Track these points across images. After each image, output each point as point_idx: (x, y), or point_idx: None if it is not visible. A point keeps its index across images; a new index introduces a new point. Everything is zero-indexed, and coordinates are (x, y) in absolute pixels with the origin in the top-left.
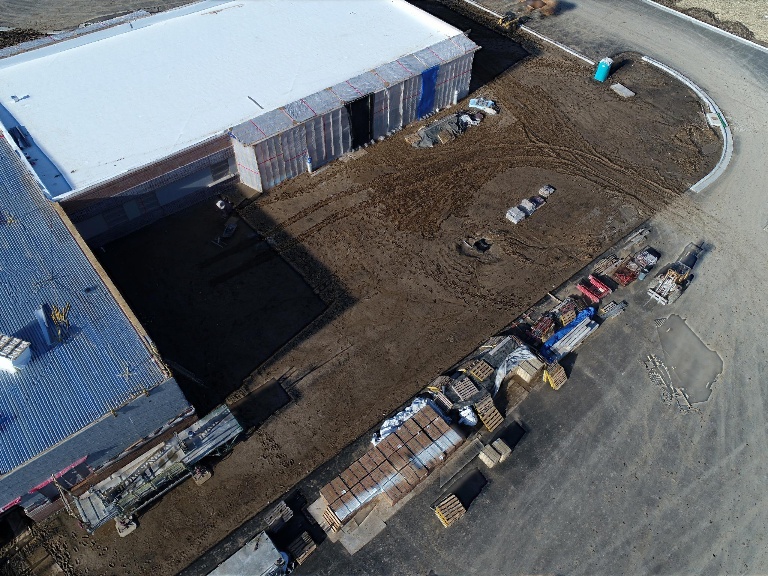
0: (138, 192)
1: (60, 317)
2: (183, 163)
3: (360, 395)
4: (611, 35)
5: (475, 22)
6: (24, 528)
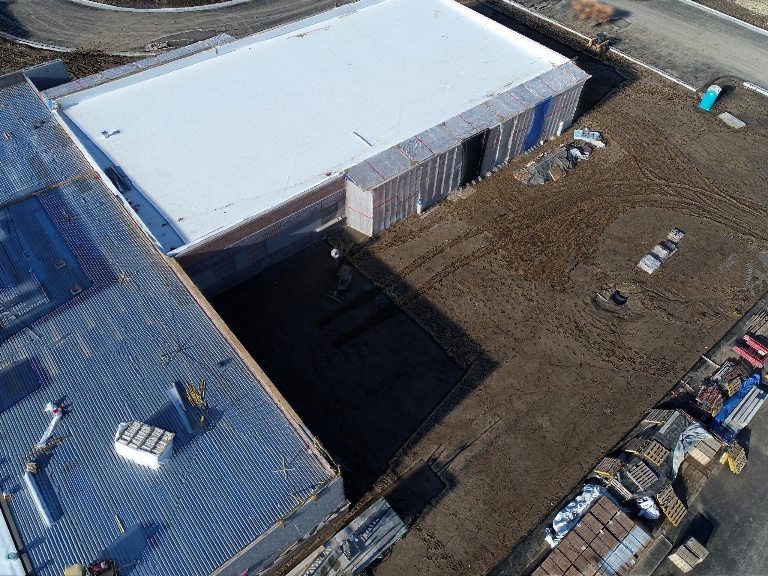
0: (250, 242)
1: (197, 397)
2: (297, 209)
3: (521, 480)
4: (706, 58)
5: (561, 43)
6: None
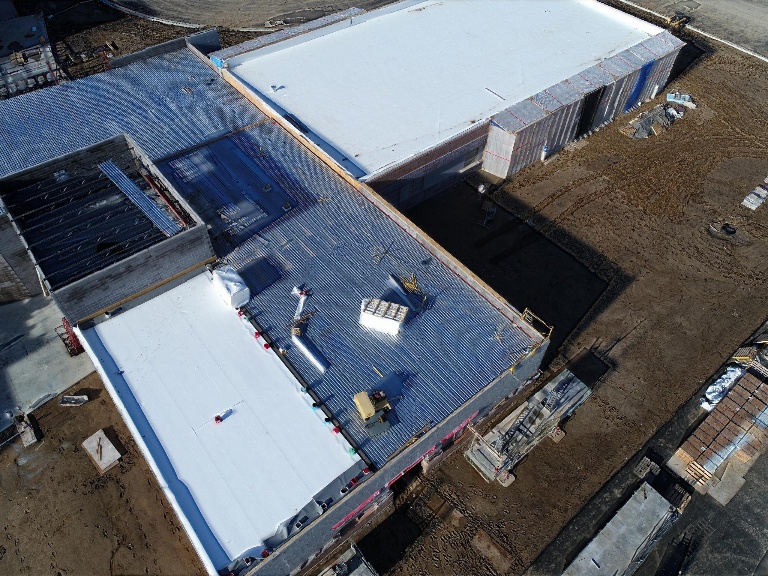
0: (415, 175)
1: (411, 286)
2: (452, 149)
3: (671, 364)
4: None
5: None
6: (414, 478)
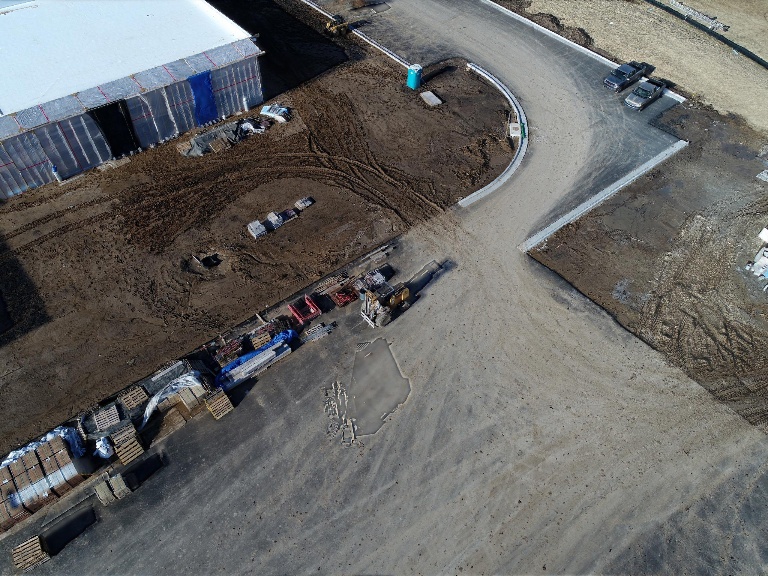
0: None
1: None
2: None
3: (3, 423)
4: (444, 41)
5: (306, 26)
6: None
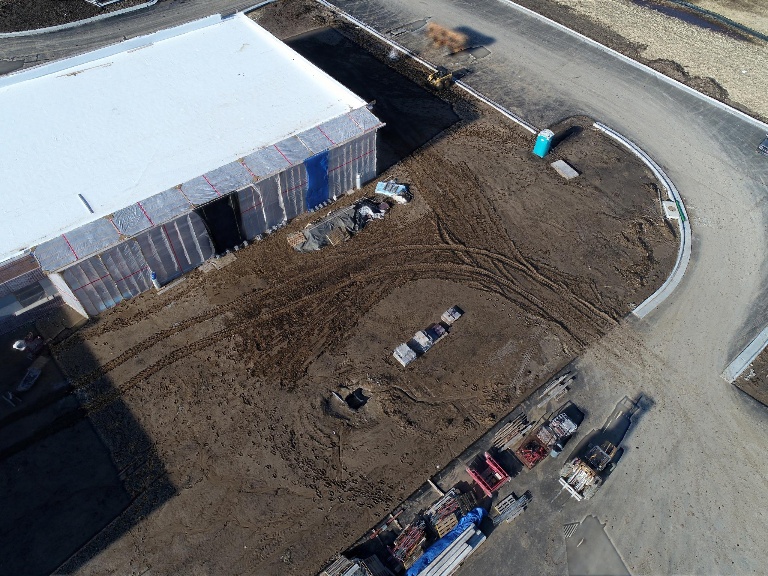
0: None
1: None
2: None
3: None
4: (560, 94)
5: (403, 76)
6: None
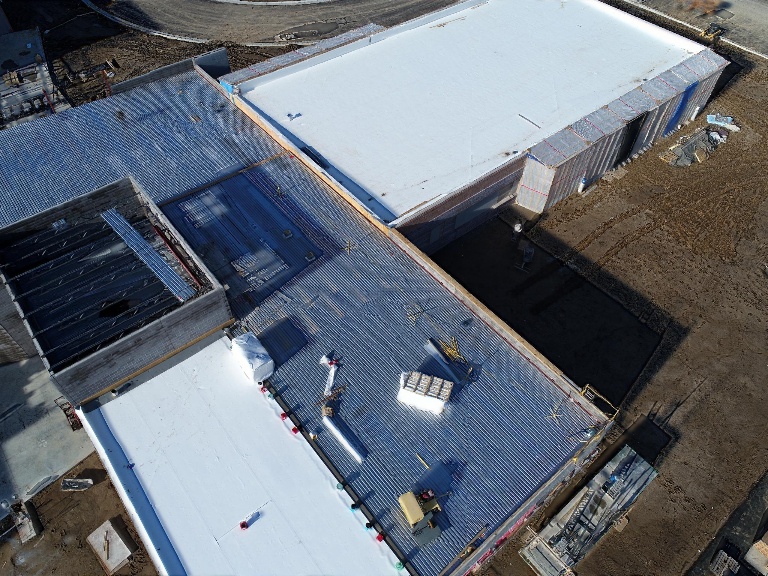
0: (448, 216)
1: (453, 353)
2: (486, 185)
3: (739, 433)
4: None
5: None
6: None
